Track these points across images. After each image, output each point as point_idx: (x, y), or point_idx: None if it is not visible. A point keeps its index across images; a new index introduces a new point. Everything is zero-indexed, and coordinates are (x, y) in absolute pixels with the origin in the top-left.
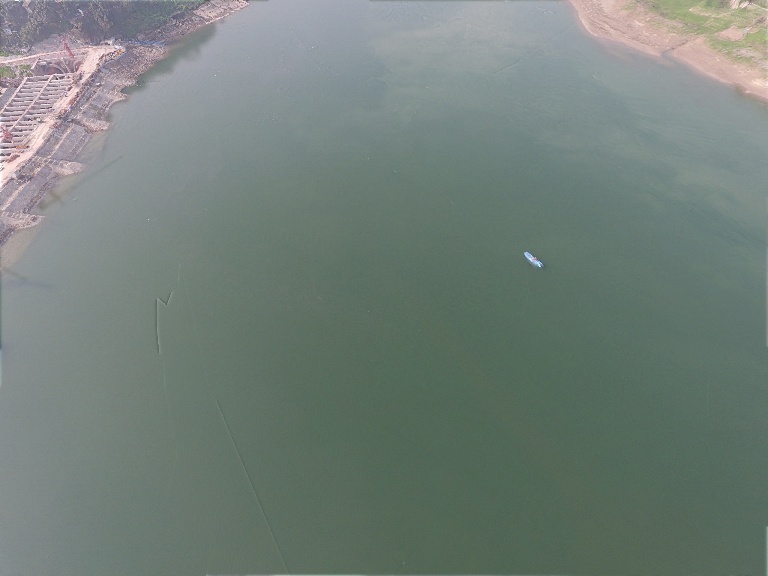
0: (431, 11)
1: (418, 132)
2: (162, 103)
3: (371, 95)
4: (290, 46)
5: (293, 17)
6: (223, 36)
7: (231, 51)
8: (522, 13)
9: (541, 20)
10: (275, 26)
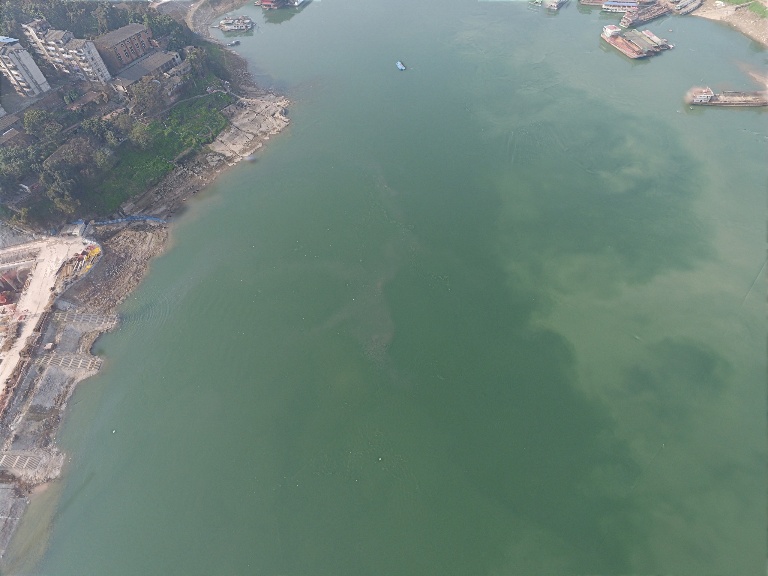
0: (571, 135)
1: (675, 493)
2: (163, 385)
3: (553, 378)
4: (370, 224)
5: (361, 151)
6: (258, 197)
7: (274, 234)
8: (724, 143)
9: (763, 159)
10: (337, 173)
